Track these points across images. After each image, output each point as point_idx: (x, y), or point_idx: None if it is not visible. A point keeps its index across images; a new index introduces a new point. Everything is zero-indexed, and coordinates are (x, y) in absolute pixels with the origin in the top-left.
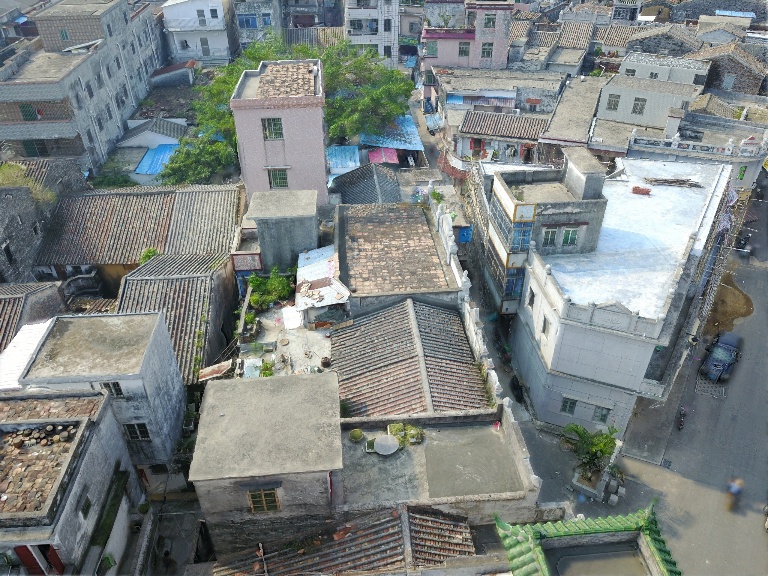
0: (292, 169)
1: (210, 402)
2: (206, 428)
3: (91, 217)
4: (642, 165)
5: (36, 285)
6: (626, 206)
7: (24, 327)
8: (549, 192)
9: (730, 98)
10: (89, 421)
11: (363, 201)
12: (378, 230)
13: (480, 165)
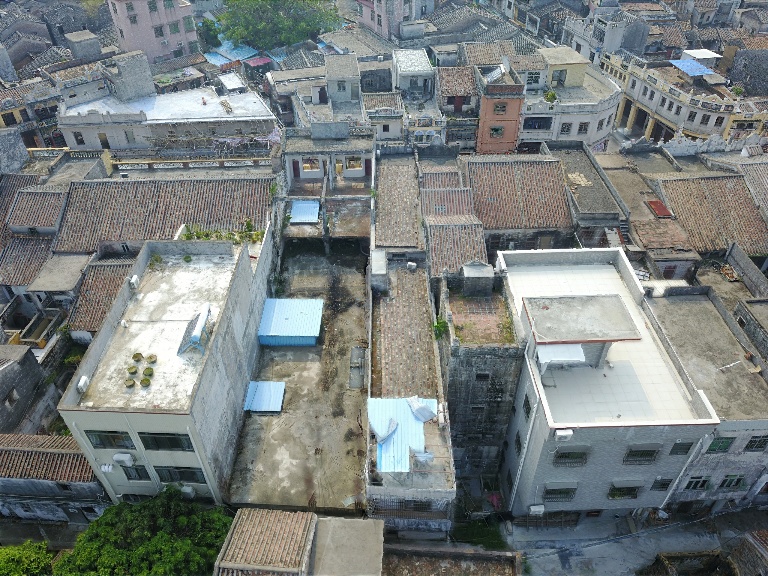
0: None
1: None
2: None
3: None
4: (249, 98)
5: (42, 39)
6: (184, 102)
7: None
8: None
9: (435, 107)
10: None
11: None
12: None
13: (228, 72)
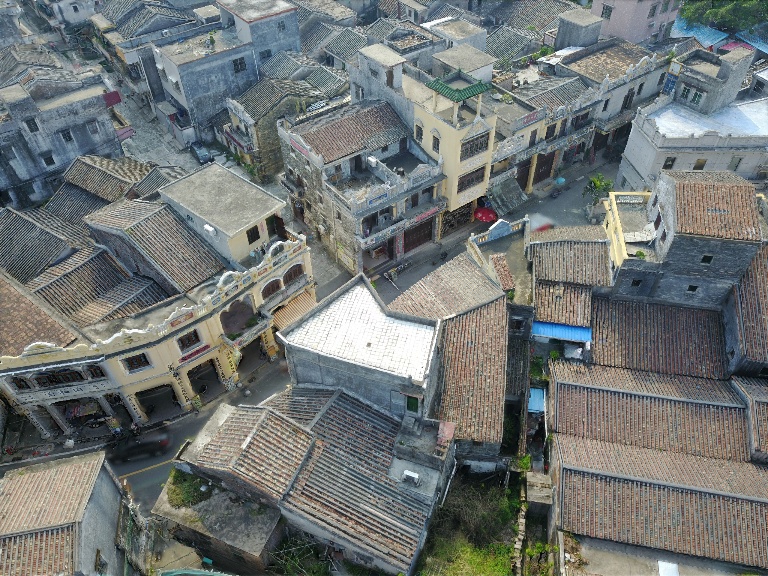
0: (615, 9)
1: (458, 47)
2: (449, 50)
3: (527, 2)
4: None
5: None
6: None
7: (449, 17)
8: (713, 70)
9: None
10: (432, 41)
11: (654, 51)
12: (620, 56)
13: (763, 68)
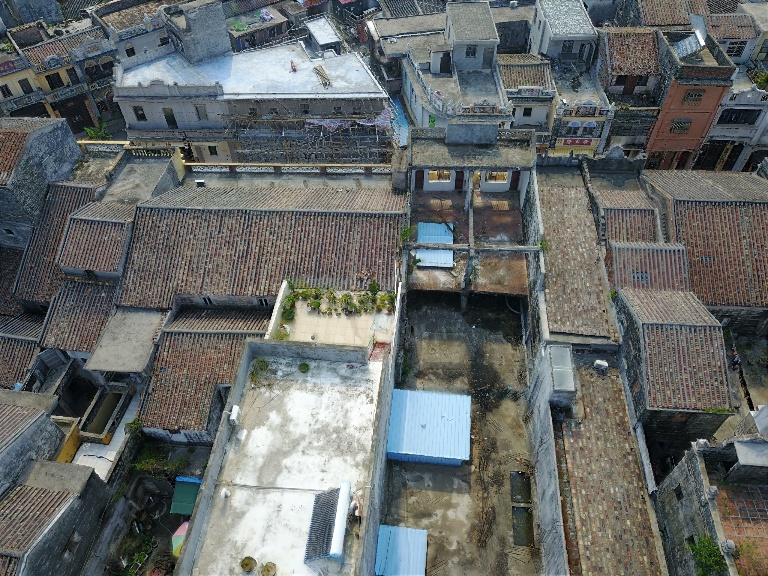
0: None
1: None
2: None
3: None
4: (349, 62)
5: None
6: (268, 66)
7: None
8: None
9: (595, 84)
10: None
11: None
12: None
13: (318, 17)
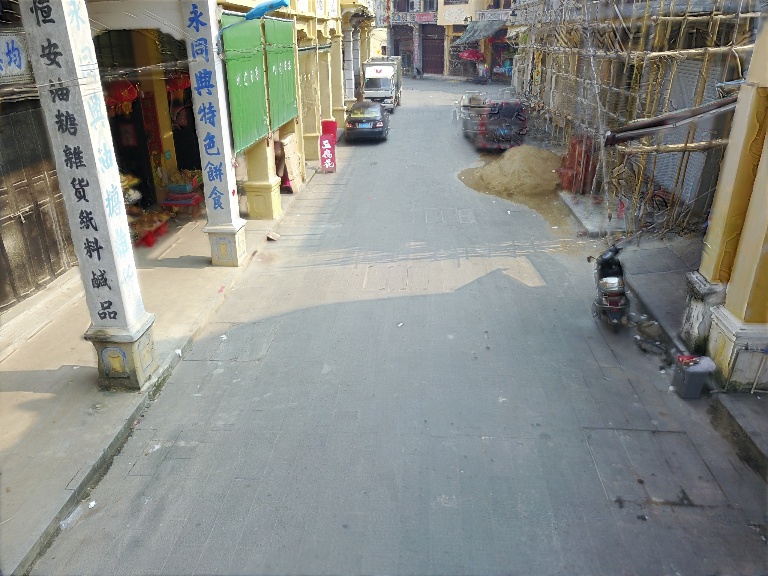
0: None
1: None
2: None
3: None
4: None
5: None
6: None
7: None
8: None
9: None
10: None
11: None
12: None
13: None
